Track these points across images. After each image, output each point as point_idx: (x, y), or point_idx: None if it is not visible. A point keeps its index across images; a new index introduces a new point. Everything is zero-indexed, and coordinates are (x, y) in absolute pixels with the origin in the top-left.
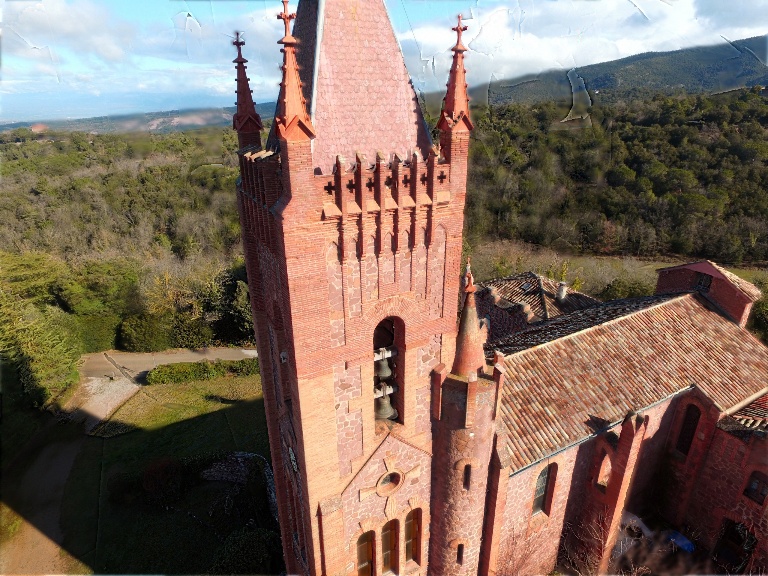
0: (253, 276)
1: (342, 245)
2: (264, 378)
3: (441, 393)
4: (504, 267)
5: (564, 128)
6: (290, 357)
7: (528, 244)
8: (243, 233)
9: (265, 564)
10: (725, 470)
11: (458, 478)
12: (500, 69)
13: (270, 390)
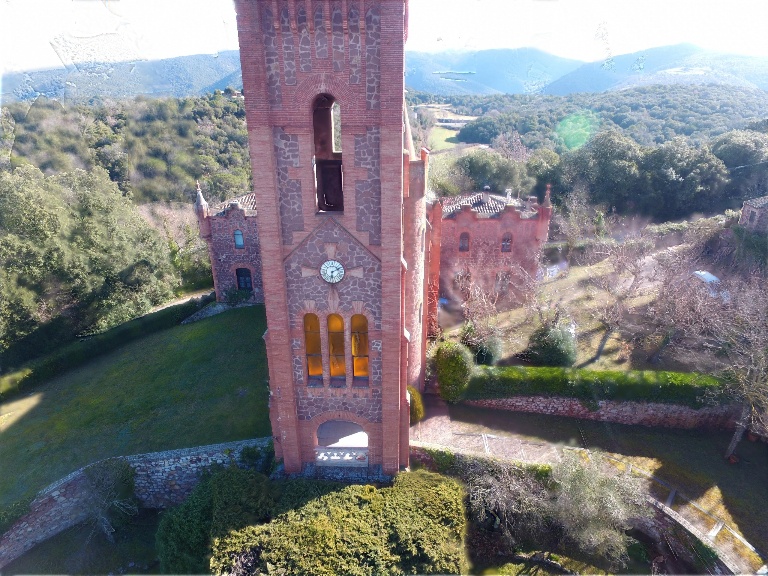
0: (265, 84)
1: (407, 16)
2: (275, 209)
3: (409, 172)
4: (161, 229)
5: (149, 91)
6: (387, 117)
7: (170, 204)
8: (249, 34)
9: (258, 474)
10: (448, 243)
11: (420, 243)
12: (71, 14)
13: (278, 224)
